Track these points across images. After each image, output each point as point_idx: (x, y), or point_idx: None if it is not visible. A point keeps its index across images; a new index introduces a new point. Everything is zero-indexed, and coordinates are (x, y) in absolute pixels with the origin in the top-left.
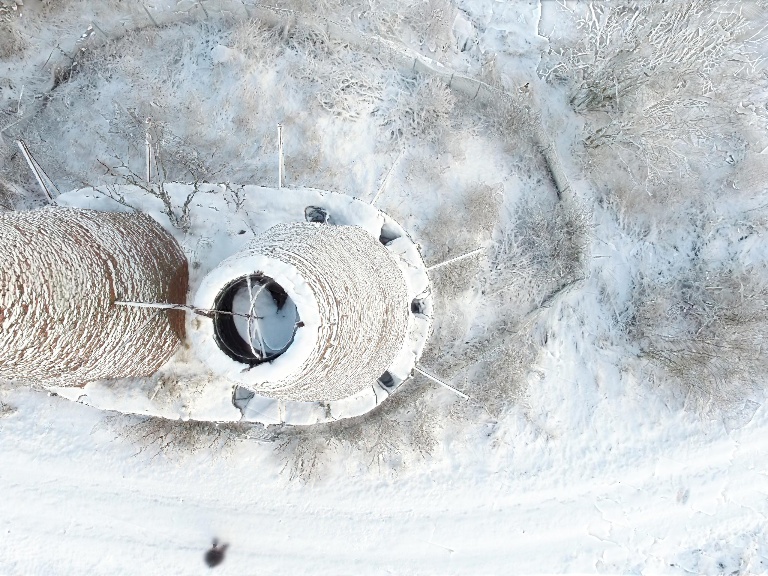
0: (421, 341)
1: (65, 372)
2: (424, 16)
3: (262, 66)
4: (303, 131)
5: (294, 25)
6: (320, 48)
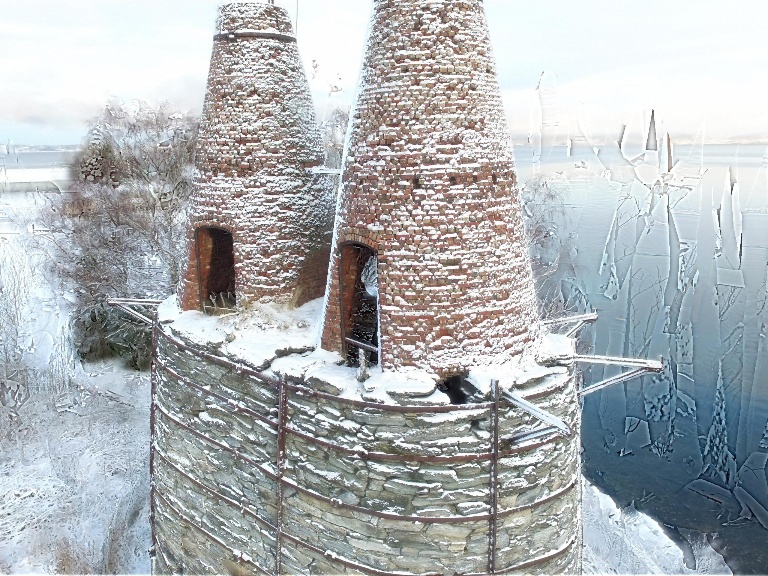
0: (531, 374)
1: (234, 171)
2: (687, 573)
3: None
4: None
5: None
6: None
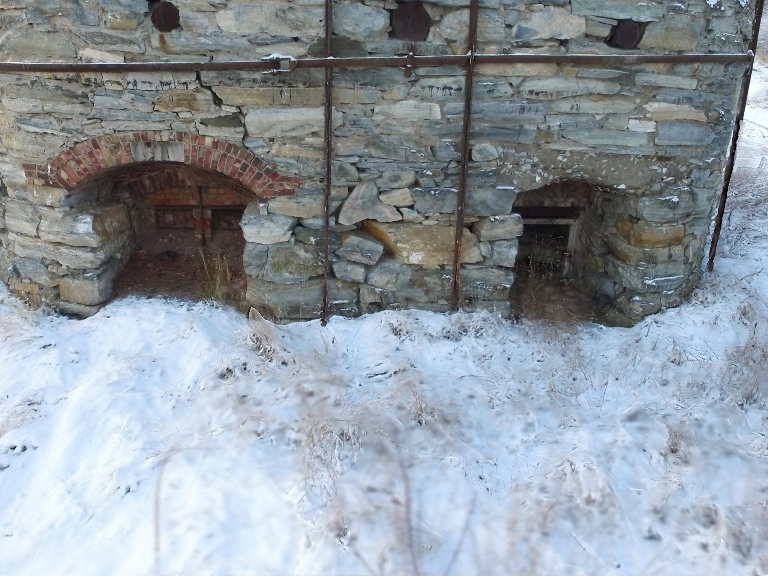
0: None
1: None
2: None
3: None
4: (418, 541)
5: None
6: None
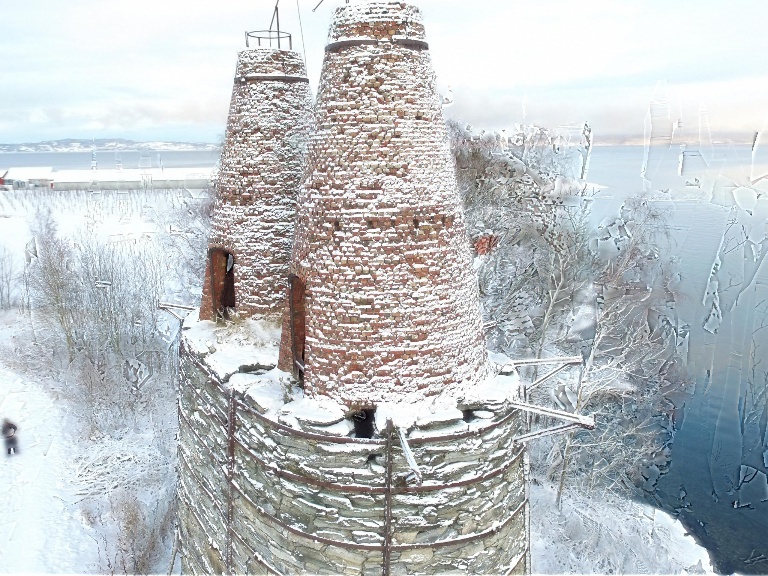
0: (437, 416)
1: None
2: None
3: (537, 536)
4: None
5: (594, 547)
6: (605, 571)
